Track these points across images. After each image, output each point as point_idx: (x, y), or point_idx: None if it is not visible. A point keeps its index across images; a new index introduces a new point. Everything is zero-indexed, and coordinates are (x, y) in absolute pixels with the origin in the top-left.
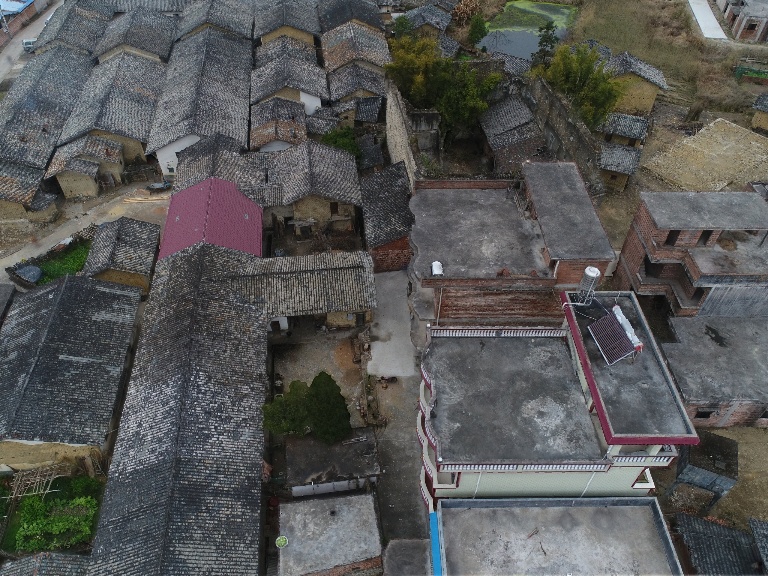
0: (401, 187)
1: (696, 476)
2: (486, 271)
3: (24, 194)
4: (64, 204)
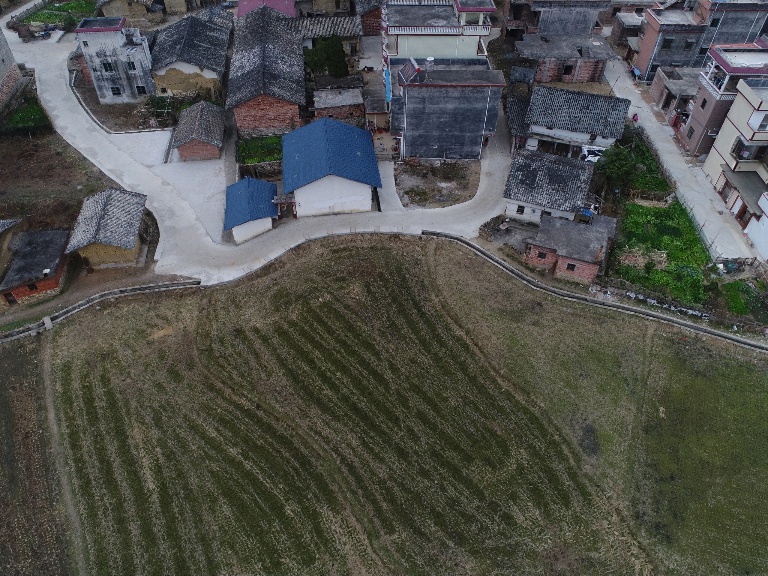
0: None
1: (517, 74)
2: None
3: (146, 1)
4: (166, 16)
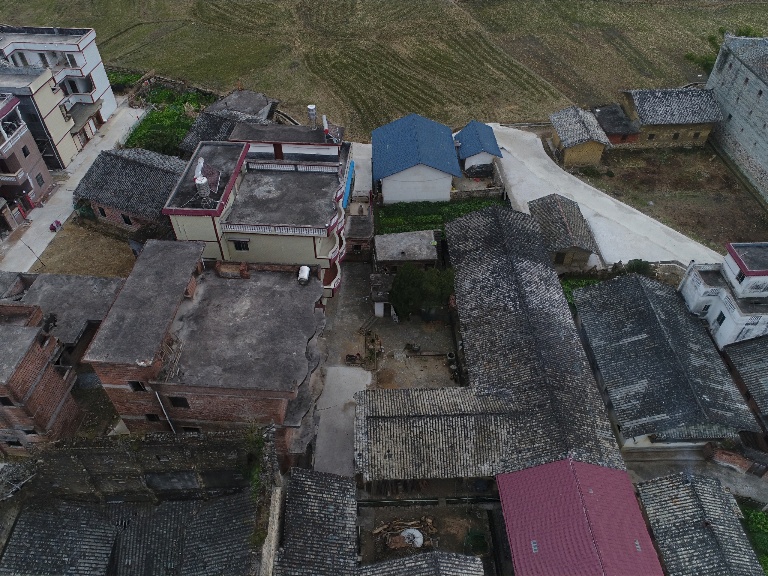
0: (289, 573)
1: None
2: (257, 284)
3: None
4: None
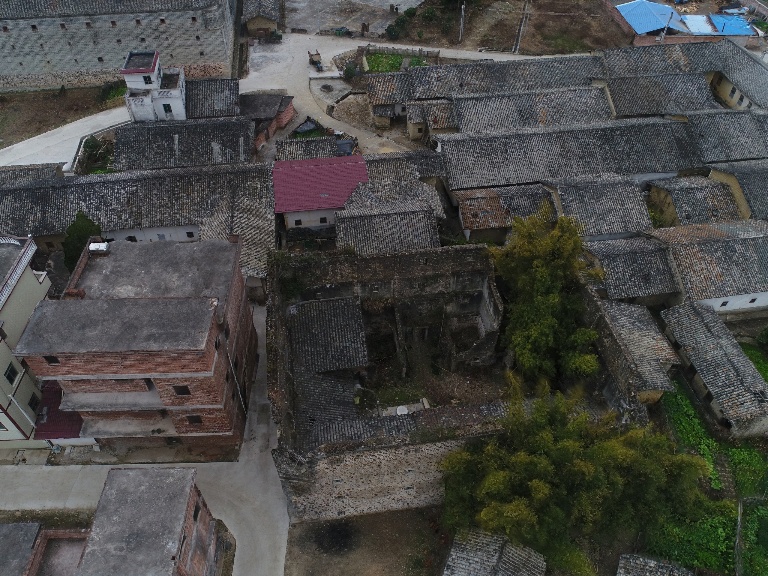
0: None
1: None
2: (95, 286)
3: (380, 99)
4: (401, 128)
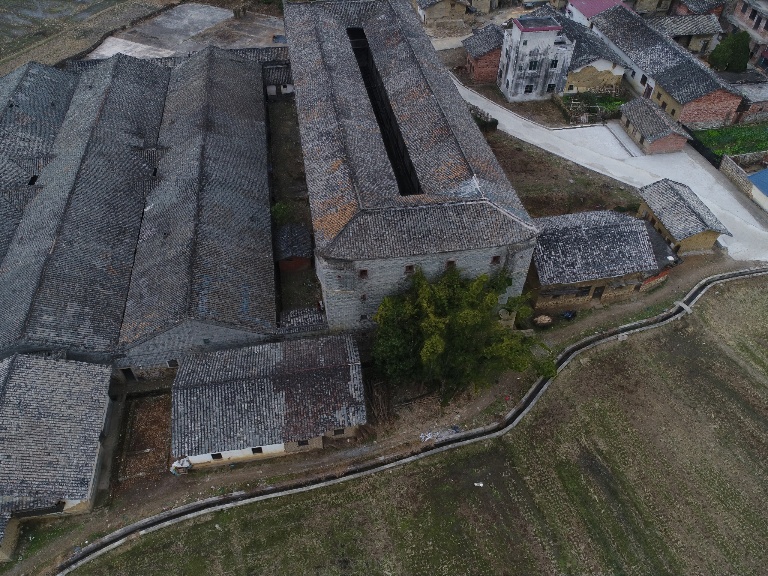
0: None
1: None
2: None
3: (466, 2)
4: None
